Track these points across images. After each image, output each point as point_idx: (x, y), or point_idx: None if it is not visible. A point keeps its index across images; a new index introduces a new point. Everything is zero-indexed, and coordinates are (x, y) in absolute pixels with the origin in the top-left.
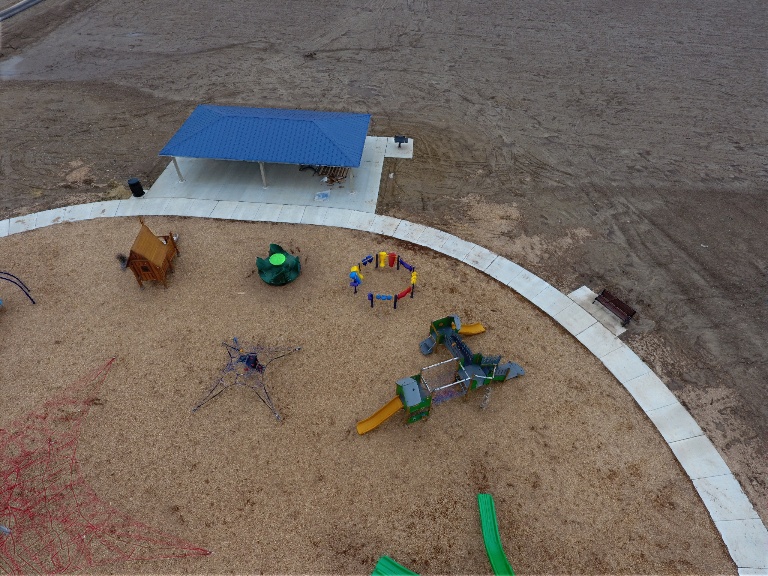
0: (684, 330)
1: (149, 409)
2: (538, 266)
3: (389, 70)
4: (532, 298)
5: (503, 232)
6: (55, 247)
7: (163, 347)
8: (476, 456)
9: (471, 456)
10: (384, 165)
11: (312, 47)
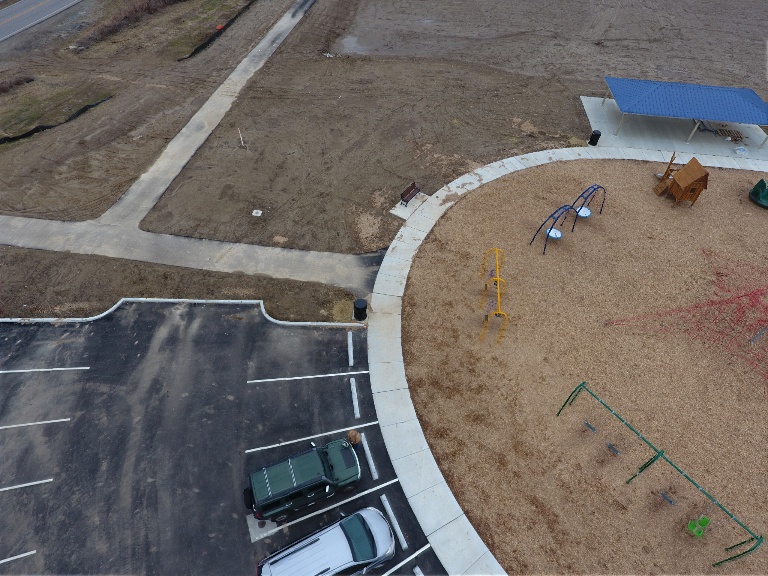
0: None
1: (765, 280)
2: None
3: (680, 58)
4: None
5: None
6: (573, 177)
7: (730, 244)
8: None
9: None
10: (764, 130)
11: (593, 36)
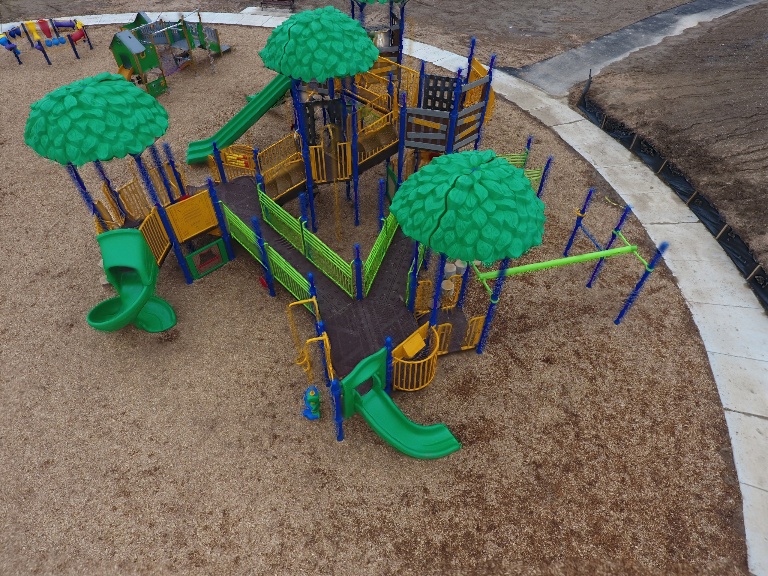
0: (333, 1)
1: None
2: (203, 8)
3: None
4: (211, 21)
5: (155, 2)
6: None
7: None
8: (229, 90)
9: (225, 92)
10: None
11: None
